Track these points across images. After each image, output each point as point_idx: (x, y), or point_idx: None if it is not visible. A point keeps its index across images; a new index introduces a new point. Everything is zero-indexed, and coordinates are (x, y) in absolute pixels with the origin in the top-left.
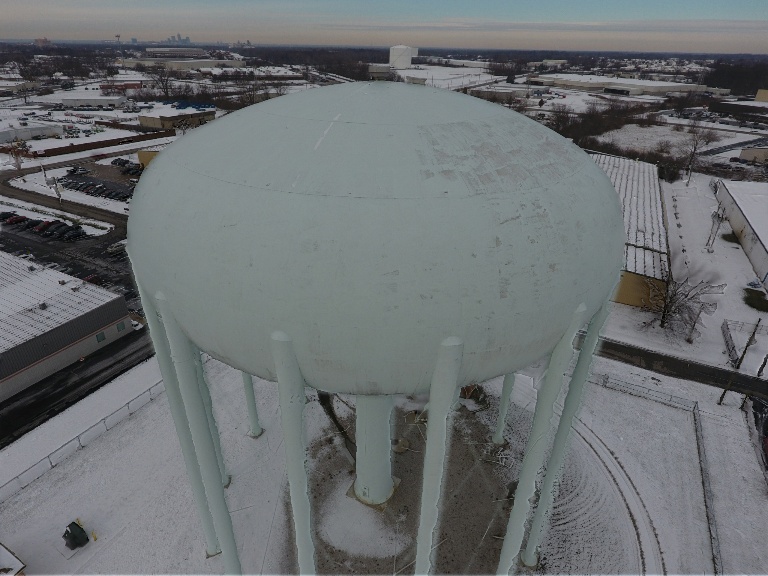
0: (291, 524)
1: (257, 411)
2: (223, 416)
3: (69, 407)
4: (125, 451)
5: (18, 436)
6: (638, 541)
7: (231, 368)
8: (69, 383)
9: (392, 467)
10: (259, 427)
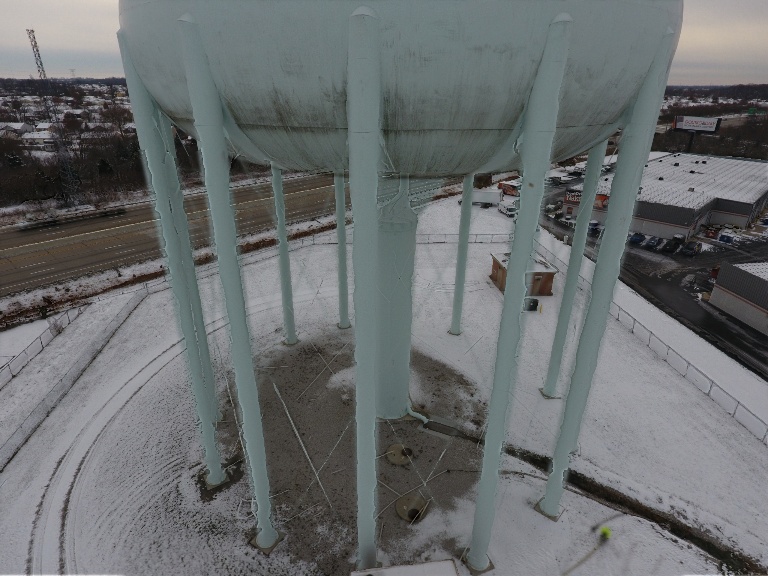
0: (426, 357)
1: (586, 410)
2: (601, 390)
3: (706, 340)
4: (605, 342)
5: (676, 318)
6: (74, 485)
7: (719, 445)
8: (760, 351)
9: (388, 429)
10: (549, 390)
